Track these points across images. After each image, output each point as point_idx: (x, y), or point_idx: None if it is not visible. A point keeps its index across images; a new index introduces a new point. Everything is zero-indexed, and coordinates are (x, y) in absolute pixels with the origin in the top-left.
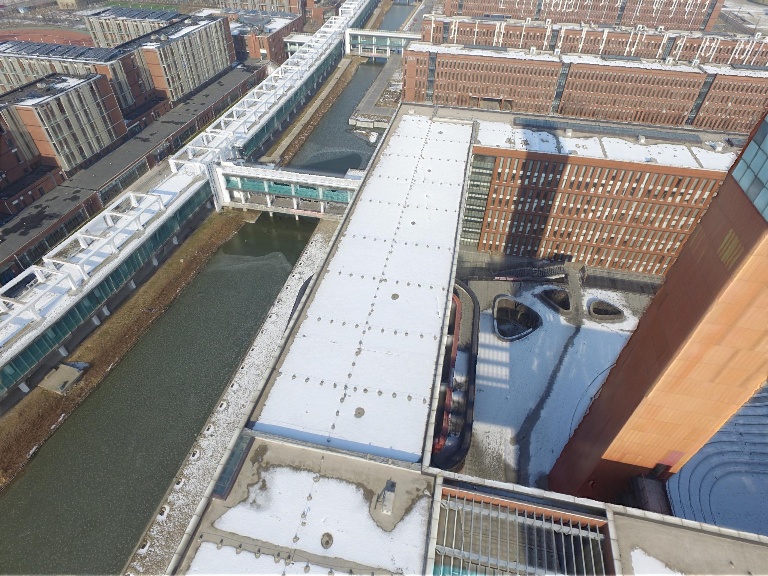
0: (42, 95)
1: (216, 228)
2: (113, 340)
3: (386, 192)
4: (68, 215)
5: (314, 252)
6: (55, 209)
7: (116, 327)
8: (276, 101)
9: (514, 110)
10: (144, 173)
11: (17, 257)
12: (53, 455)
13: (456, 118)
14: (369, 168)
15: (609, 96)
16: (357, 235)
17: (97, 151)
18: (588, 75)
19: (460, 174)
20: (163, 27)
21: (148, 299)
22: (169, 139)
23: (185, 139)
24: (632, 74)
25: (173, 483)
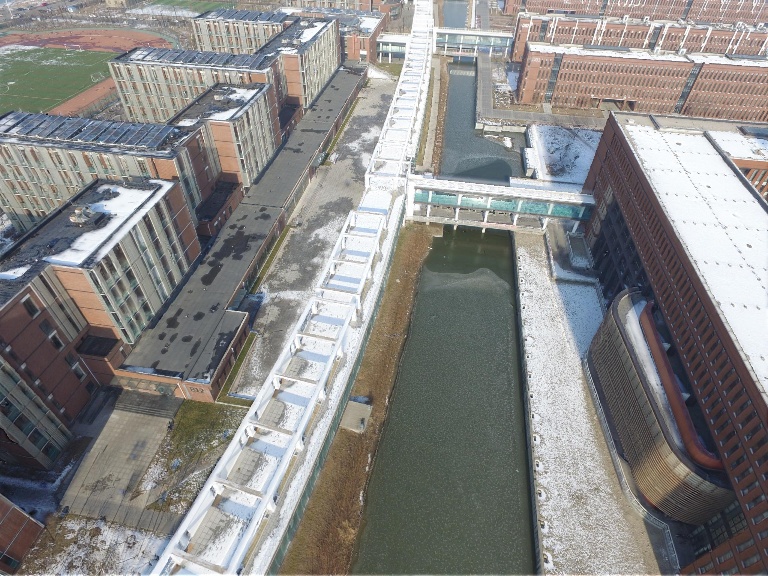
0: (225, 108)
1: (411, 244)
2: (378, 370)
3: (690, 212)
4: (270, 235)
5: (528, 268)
6: (253, 229)
7: (374, 356)
8: (417, 107)
9: (635, 111)
10: (306, 186)
11: (243, 283)
12: (384, 500)
13: (685, 128)
14: (653, 186)
15: (737, 96)
16: (708, 261)
17: (265, 165)
18: (719, 75)
19: (744, 190)
20: (283, 30)
21: (388, 324)
22: (320, 149)
23: (326, 148)
24: (765, 74)
25: (539, 527)
